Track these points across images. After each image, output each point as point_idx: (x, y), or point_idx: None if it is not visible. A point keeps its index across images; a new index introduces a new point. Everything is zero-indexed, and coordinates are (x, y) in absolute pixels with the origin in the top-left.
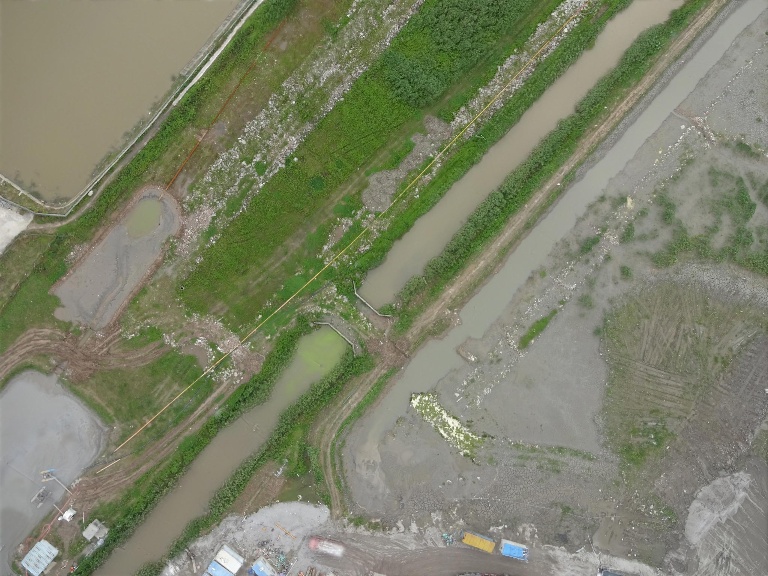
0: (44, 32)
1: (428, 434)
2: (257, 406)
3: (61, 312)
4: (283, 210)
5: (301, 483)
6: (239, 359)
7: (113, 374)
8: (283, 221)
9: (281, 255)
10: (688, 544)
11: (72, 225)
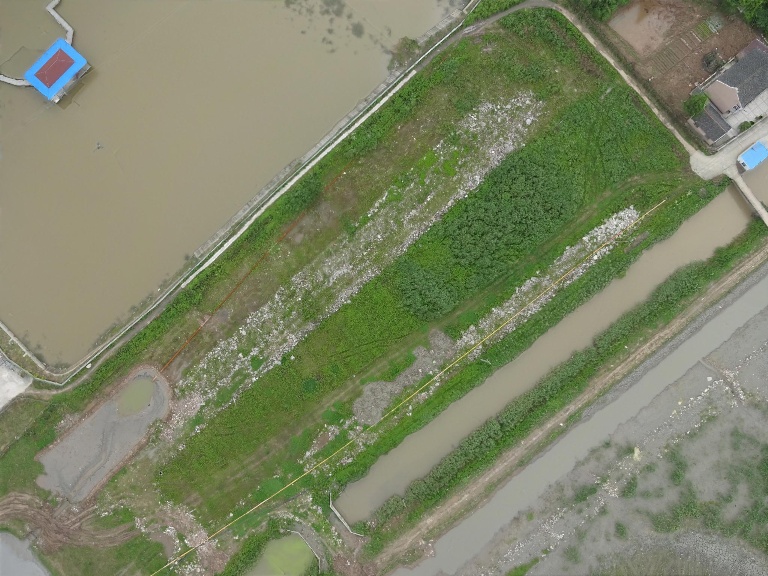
0: (72, 199)
1: None
2: None
3: (43, 479)
4: (272, 408)
5: None
6: (204, 555)
7: (81, 550)
8: (270, 420)
9: (262, 454)
10: None
11: (67, 394)
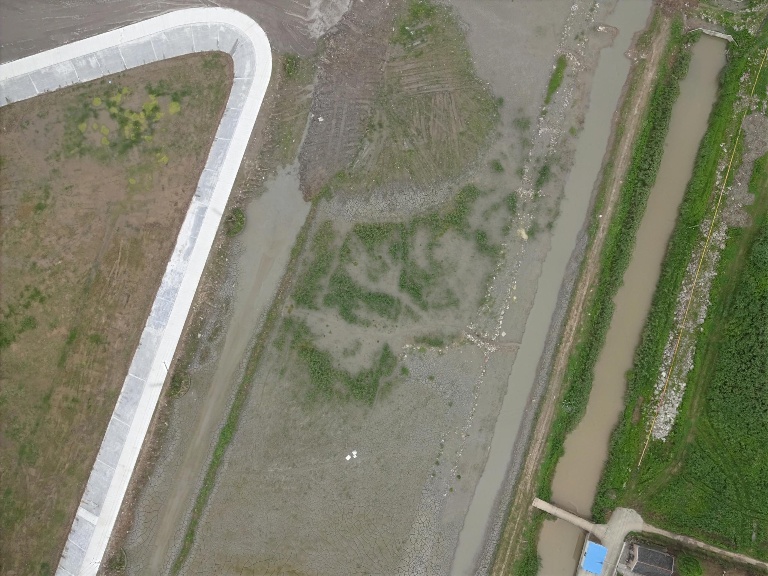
0: None
1: None
2: None
3: None
4: None
5: None
6: None
7: None
8: None
9: None
10: None
11: None
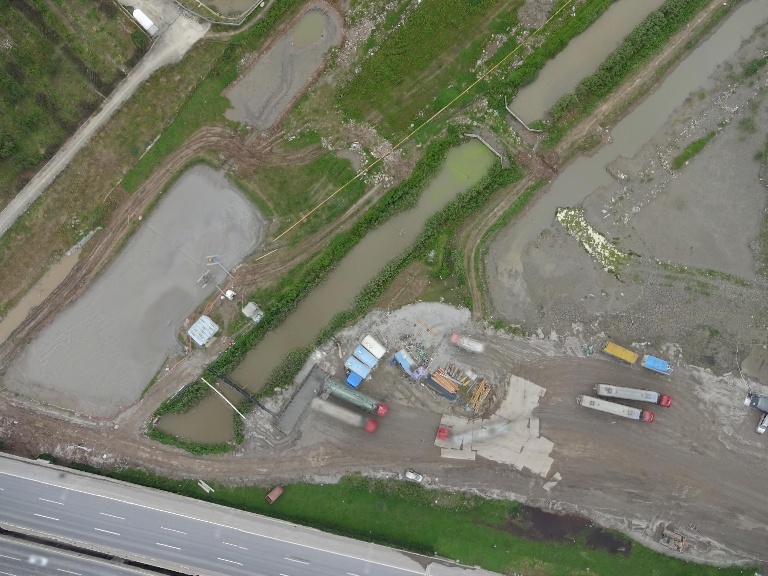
0: None
1: (572, 248)
2: (404, 212)
3: (231, 113)
4: (439, 25)
5: (444, 286)
6: (390, 164)
7: (274, 171)
8: (439, 36)
9: (435, 68)
10: None
11: (244, 34)
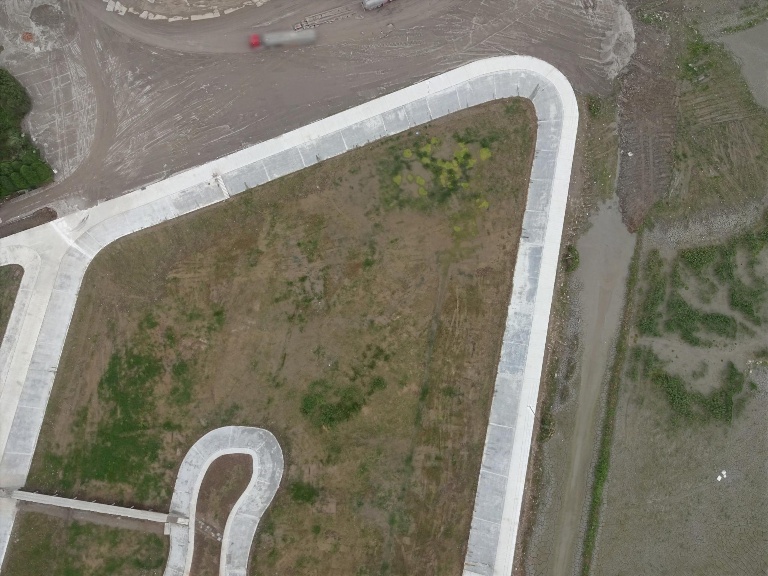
0: None
1: None
2: None
3: None
4: None
5: None
6: None
7: None
8: None
9: None
10: (624, 3)
11: None
